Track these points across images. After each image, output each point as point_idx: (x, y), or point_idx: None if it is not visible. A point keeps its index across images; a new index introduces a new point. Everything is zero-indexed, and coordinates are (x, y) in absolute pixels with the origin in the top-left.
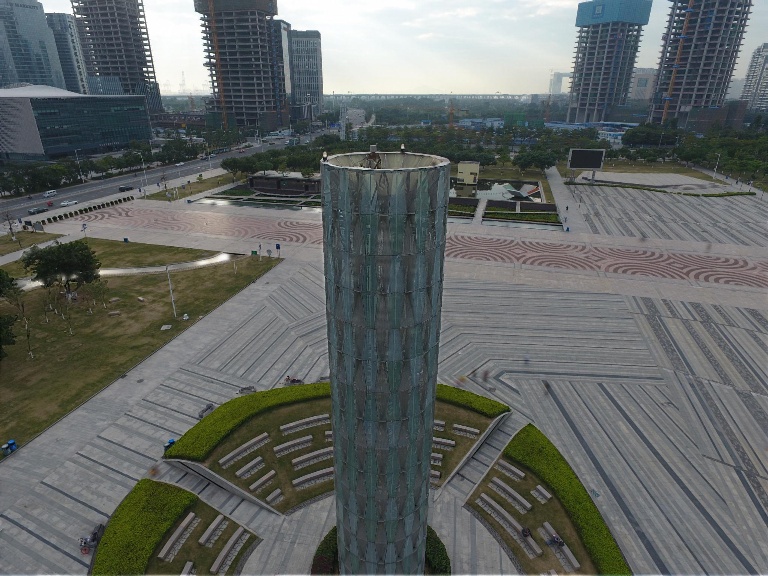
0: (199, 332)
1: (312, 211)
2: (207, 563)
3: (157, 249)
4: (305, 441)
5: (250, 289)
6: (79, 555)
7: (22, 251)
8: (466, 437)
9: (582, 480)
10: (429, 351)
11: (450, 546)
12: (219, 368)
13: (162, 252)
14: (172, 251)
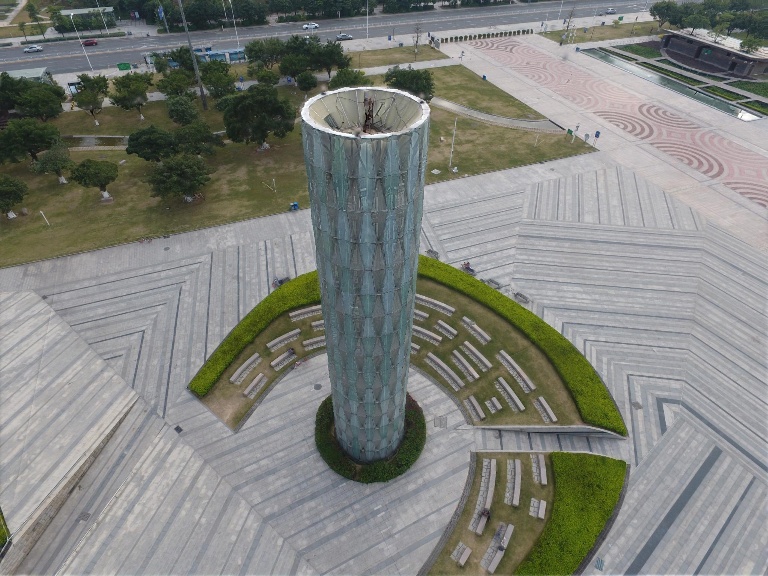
0: (452, 188)
1: (702, 102)
2: (306, 337)
3: (499, 95)
4: (421, 315)
5: (530, 168)
6: (271, 285)
7: (413, 64)
8: (539, 414)
9: (604, 545)
10: (363, 296)
11: (427, 461)
12: (435, 225)
13: (500, 100)
14: (508, 102)
